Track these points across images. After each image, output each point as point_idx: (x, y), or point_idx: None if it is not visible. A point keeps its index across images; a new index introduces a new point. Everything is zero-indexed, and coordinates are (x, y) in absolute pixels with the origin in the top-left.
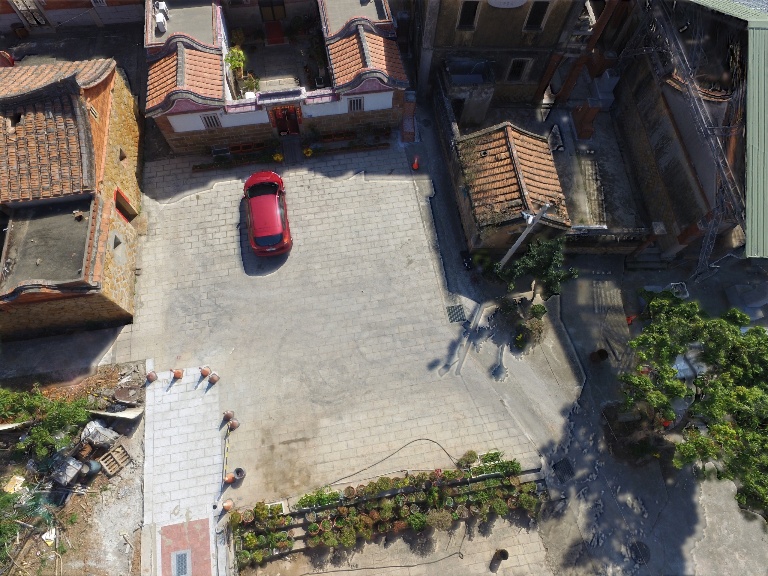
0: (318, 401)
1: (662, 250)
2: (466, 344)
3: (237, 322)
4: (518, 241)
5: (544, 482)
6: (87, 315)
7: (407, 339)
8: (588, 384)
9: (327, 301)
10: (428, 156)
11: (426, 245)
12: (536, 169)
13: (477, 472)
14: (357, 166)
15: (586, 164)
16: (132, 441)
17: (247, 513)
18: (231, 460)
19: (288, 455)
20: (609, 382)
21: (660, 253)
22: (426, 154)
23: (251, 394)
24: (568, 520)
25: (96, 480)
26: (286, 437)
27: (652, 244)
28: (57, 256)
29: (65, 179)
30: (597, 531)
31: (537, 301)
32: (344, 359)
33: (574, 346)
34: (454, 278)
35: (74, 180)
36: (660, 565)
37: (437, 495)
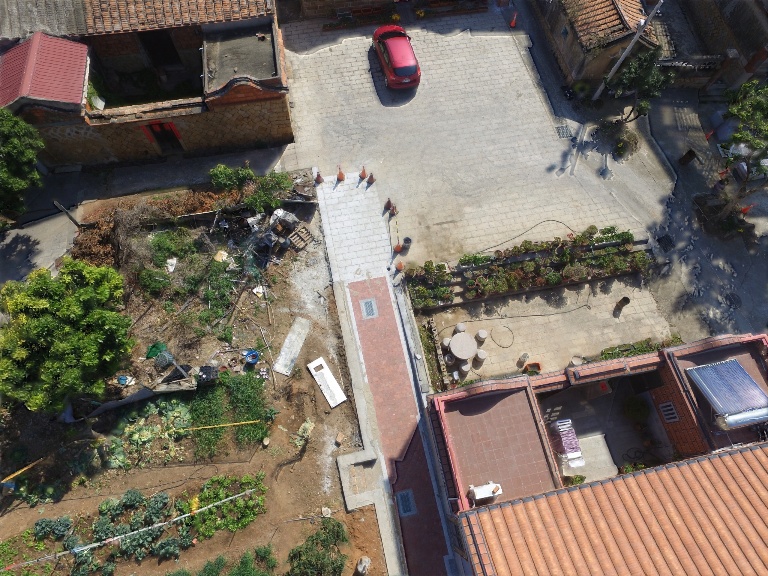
0: (460, 195)
1: (729, 85)
2: (576, 153)
3: (382, 140)
4: (625, 53)
5: (651, 252)
6: (260, 131)
7: (526, 150)
8: (679, 181)
9: (455, 124)
10: (522, 17)
11: (531, 83)
12: (629, 7)
13: (598, 241)
14: (463, 25)
15: (656, 24)
16: (311, 226)
17: (419, 269)
18: (396, 237)
19: (442, 233)
20: (696, 179)
21: (727, 88)
22: (520, 15)
23: (404, 191)
24: (673, 279)
25: (286, 254)
26: (438, 220)
27: (719, 82)
28: (250, 65)
29: (251, 4)
30: (697, 286)
31: (630, 122)
32: (476, 165)
33: (665, 154)
34: (559, 106)
35: (259, 5)
36: (750, 309)
37: (569, 256)
